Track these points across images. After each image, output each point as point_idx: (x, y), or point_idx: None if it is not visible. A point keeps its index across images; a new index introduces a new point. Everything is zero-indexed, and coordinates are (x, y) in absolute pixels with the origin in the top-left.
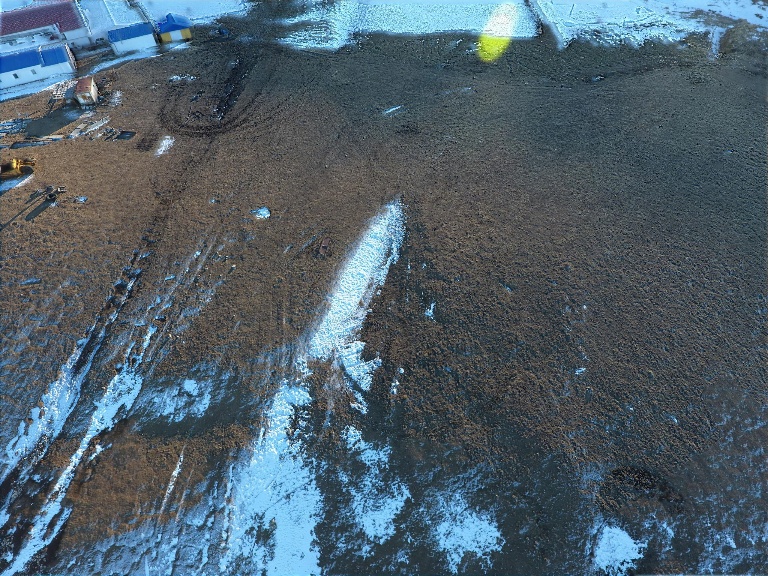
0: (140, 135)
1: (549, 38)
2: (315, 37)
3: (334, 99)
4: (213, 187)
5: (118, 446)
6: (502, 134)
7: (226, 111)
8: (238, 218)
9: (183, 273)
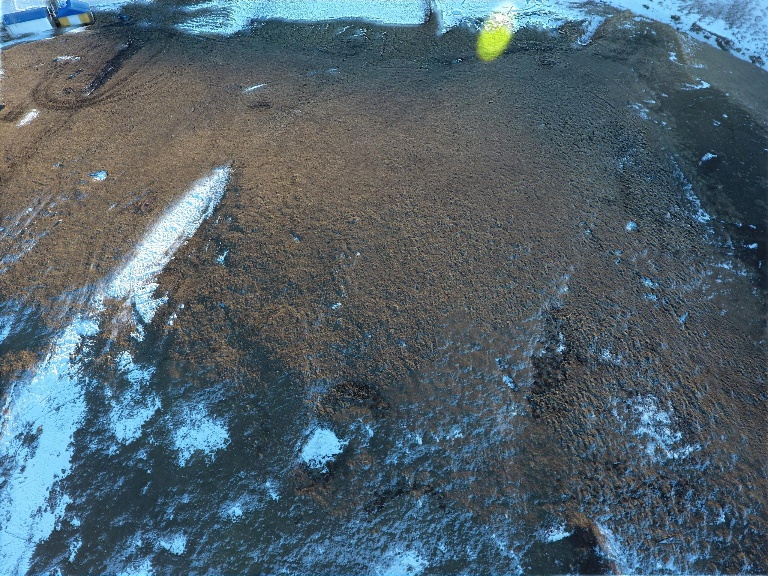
0: (9, 108)
1: (431, 25)
2: (211, 23)
3: (202, 78)
4: (61, 153)
5: None
6: (345, 109)
7: (96, 88)
8: (76, 180)
9: (12, 226)
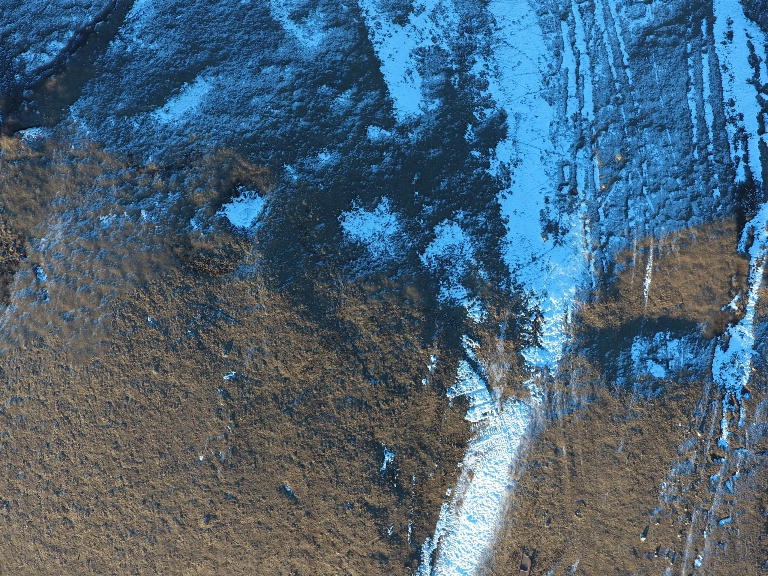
0: None
1: None
2: None
3: None
4: None
5: (715, 308)
6: None
7: None
8: None
9: (710, 529)
